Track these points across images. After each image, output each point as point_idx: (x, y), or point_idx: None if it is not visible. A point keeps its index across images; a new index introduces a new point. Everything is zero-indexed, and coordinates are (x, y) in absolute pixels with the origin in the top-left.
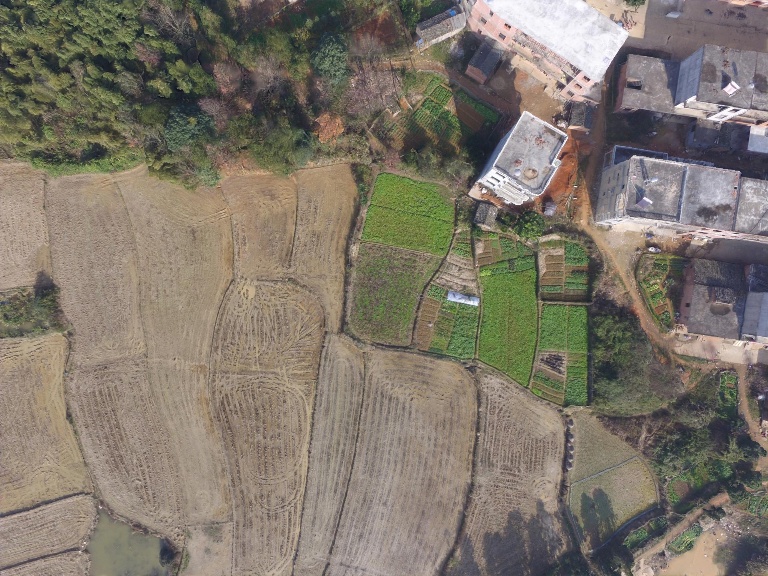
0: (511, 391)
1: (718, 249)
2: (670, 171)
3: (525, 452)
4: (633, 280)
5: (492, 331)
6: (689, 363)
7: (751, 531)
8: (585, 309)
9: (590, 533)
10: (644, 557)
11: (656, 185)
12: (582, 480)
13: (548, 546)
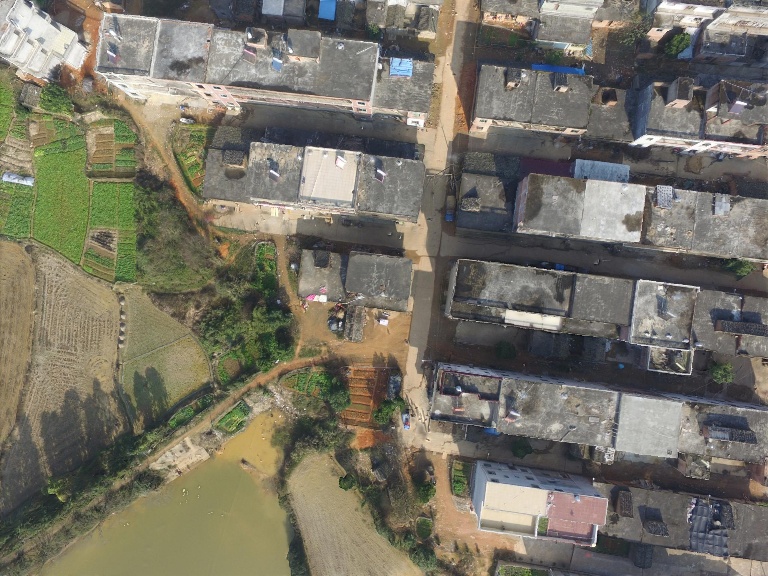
0: (68, 270)
1: (253, 118)
2: (143, 27)
3: (81, 331)
4: (171, 153)
5: (45, 210)
6: (227, 235)
7: (307, 412)
8: (134, 186)
9: (143, 413)
10: (189, 436)
11: (129, 41)
12: (134, 358)
13: (105, 426)
